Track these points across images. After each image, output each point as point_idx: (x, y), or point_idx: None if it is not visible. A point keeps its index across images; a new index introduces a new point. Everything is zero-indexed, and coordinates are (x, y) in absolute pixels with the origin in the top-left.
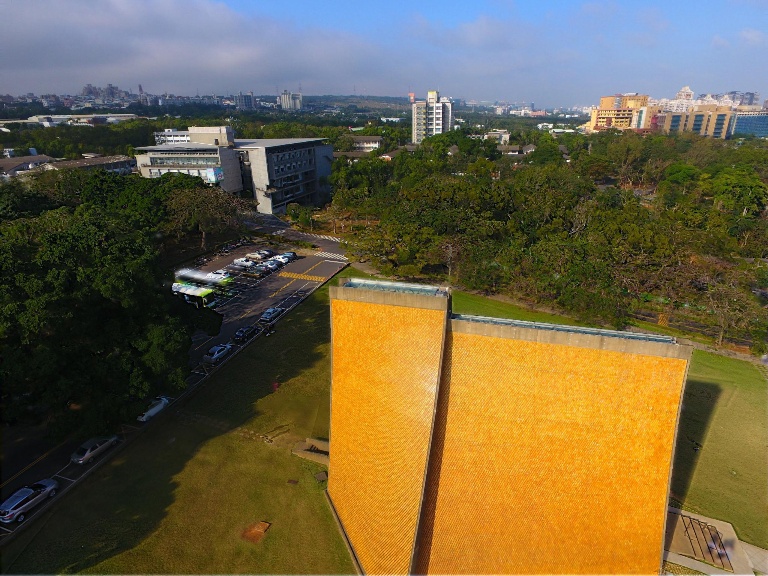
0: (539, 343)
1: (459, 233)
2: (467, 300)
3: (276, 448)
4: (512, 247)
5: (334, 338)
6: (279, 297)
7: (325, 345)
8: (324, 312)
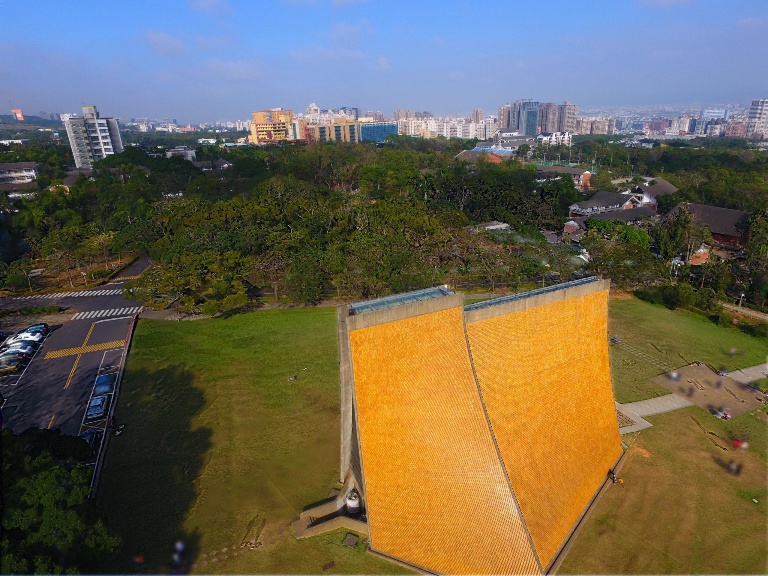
0: (527, 310)
1: (268, 250)
2: (303, 315)
3: (273, 546)
4: (331, 252)
5: (355, 375)
6: (82, 383)
7: (206, 413)
8: (166, 378)
